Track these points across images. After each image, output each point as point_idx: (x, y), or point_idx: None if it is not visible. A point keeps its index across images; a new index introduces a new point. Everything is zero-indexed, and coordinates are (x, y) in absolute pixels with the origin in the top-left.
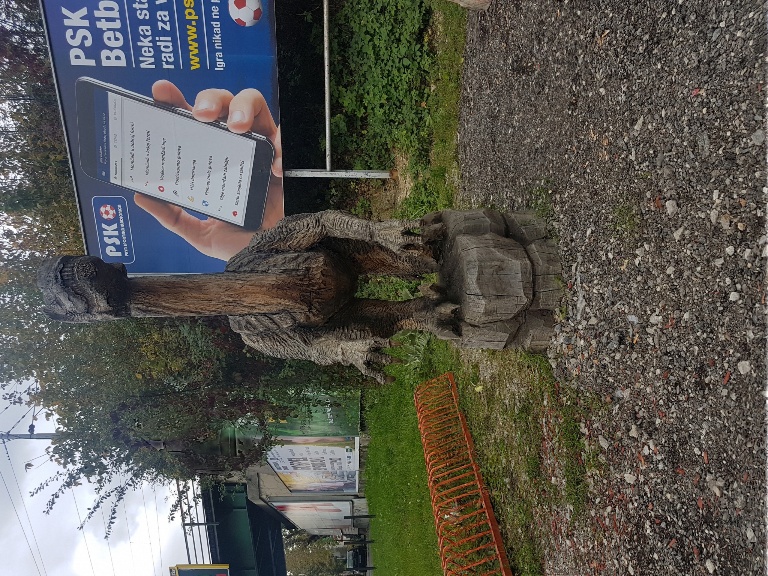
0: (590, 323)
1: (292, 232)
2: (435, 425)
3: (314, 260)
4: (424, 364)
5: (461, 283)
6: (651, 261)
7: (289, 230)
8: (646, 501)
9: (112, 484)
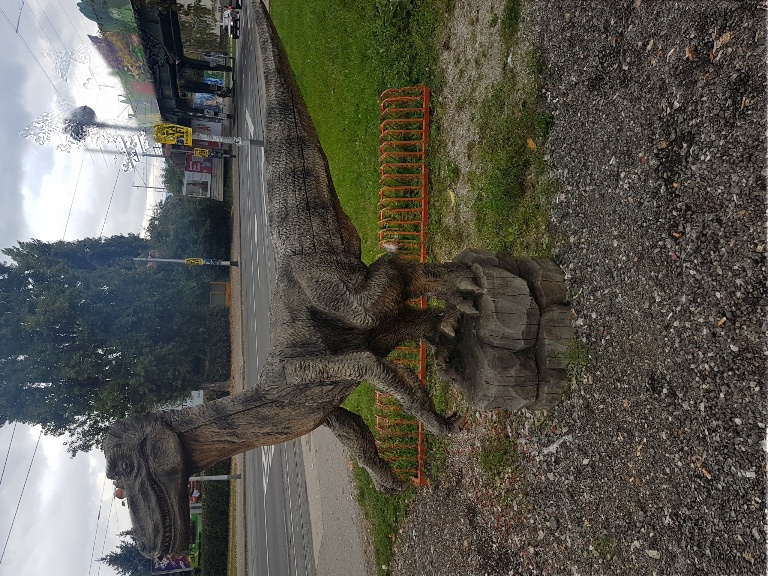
0: (548, 477)
1: (333, 377)
2: (398, 168)
3: (349, 389)
4: (400, 13)
5: (472, 381)
6: (596, 568)
7: (330, 376)
8: (517, 567)
9: (52, 142)
